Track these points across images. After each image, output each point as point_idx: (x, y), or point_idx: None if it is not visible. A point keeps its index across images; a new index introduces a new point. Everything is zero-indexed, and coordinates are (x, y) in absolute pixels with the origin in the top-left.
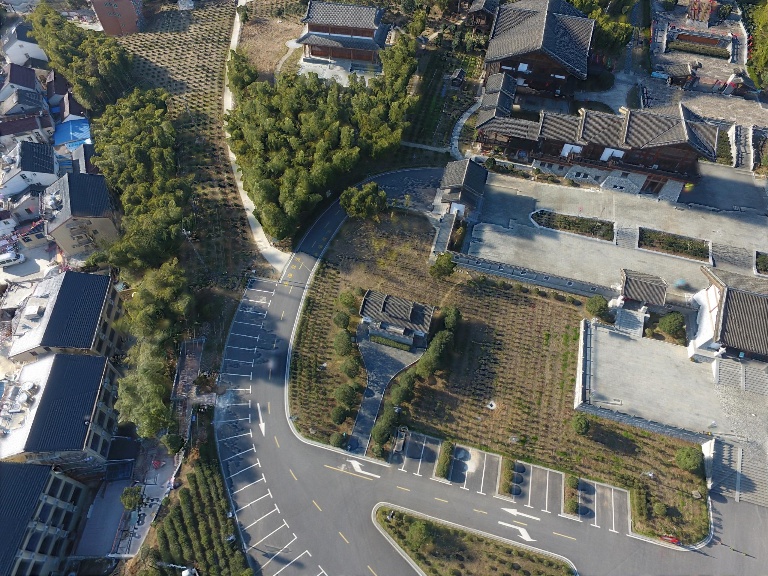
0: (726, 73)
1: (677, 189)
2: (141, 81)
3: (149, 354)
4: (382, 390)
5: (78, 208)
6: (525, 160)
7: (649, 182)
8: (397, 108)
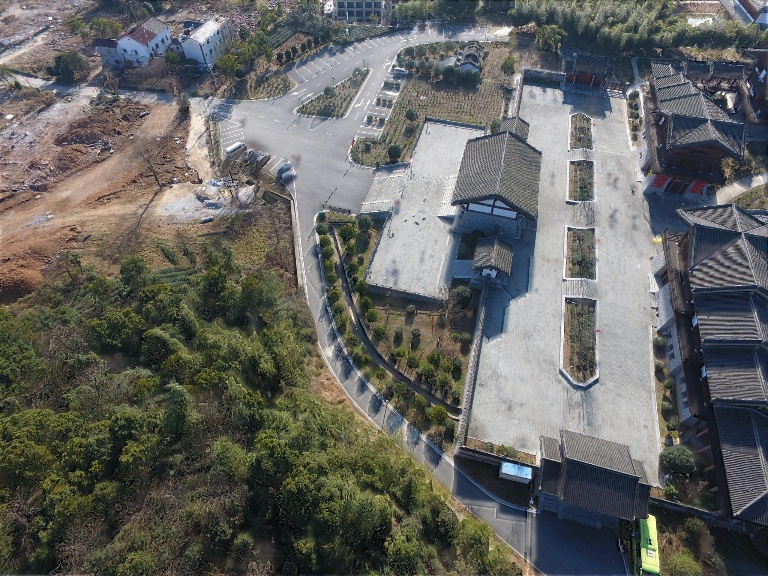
0: None
1: (651, 178)
2: None
3: (433, 4)
4: None
5: None
6: None
7: None
8: (645, 24)
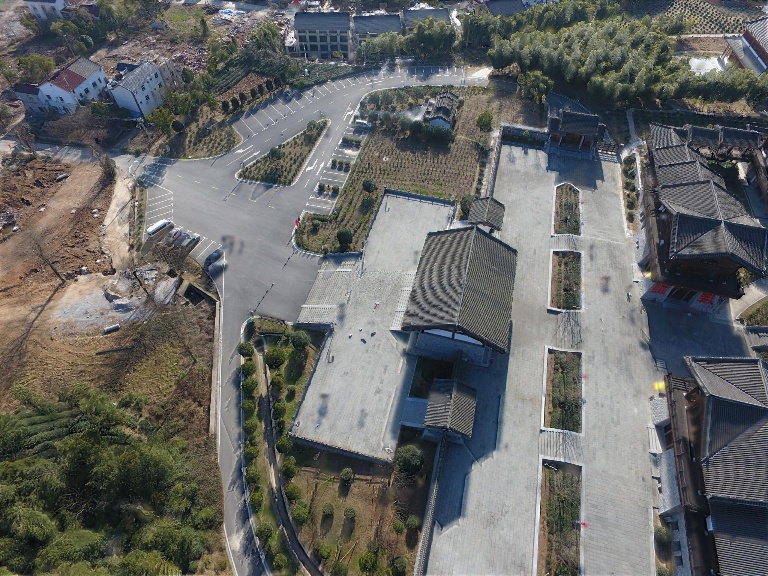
0: None
1: None
2: (639, 10)
3: (404, 39)
4: None
5: (493, 4)
6: None
7: None
8: (642, 74)
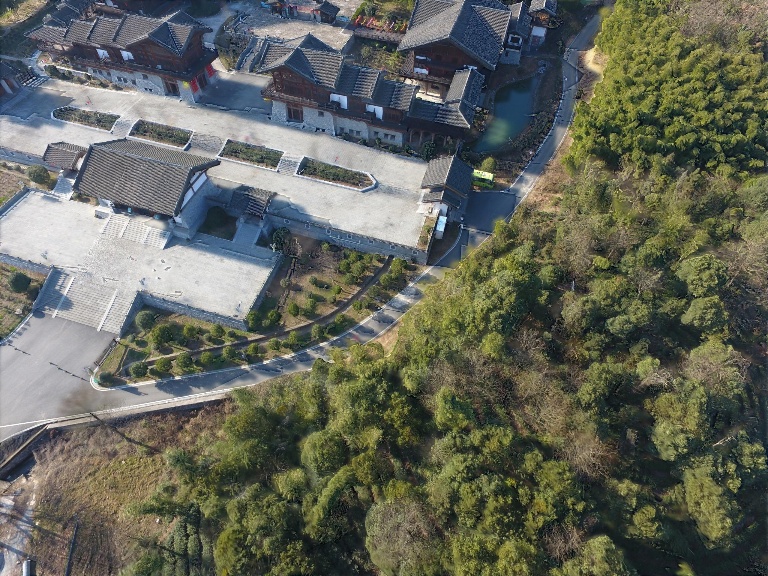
0: (339, 6)
1: (187, 89)
2: None
3: None
4: None
5: None
6: (87, 68)
7: (169, 84)
8: None
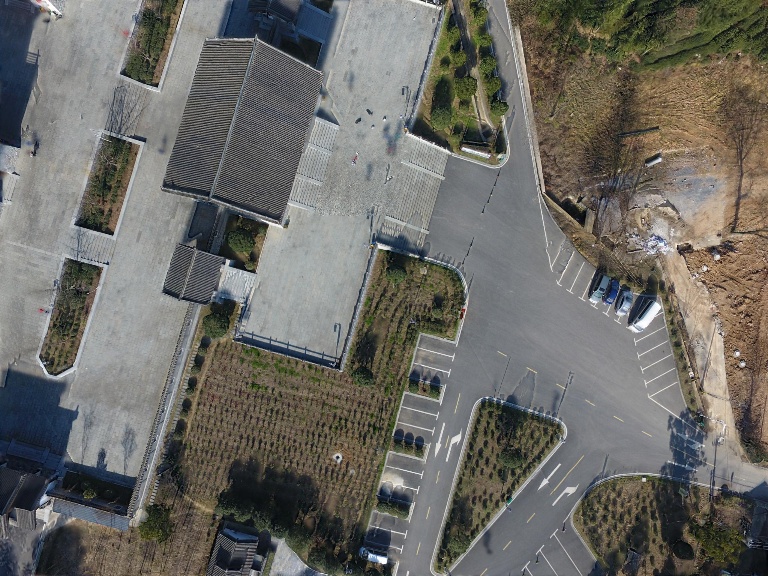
0: None
1: None
2: None
3: None
4: (321, 575)
5: None
6: None
7: None
8: None
